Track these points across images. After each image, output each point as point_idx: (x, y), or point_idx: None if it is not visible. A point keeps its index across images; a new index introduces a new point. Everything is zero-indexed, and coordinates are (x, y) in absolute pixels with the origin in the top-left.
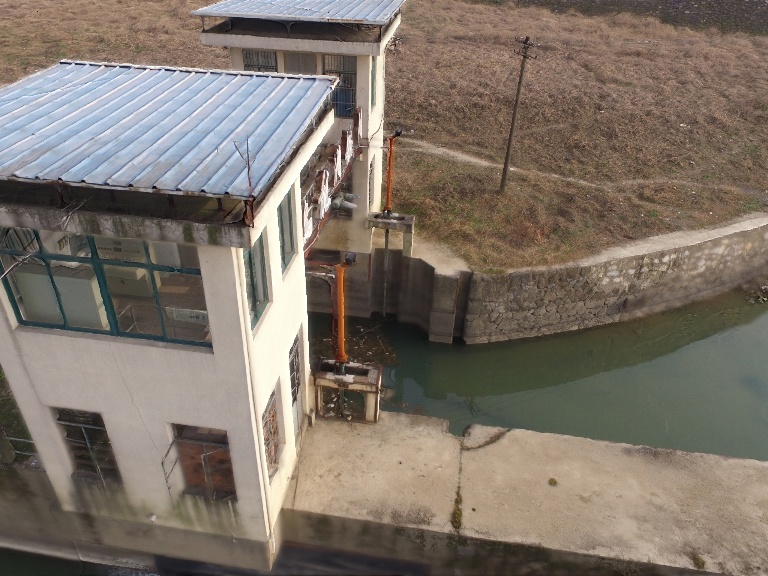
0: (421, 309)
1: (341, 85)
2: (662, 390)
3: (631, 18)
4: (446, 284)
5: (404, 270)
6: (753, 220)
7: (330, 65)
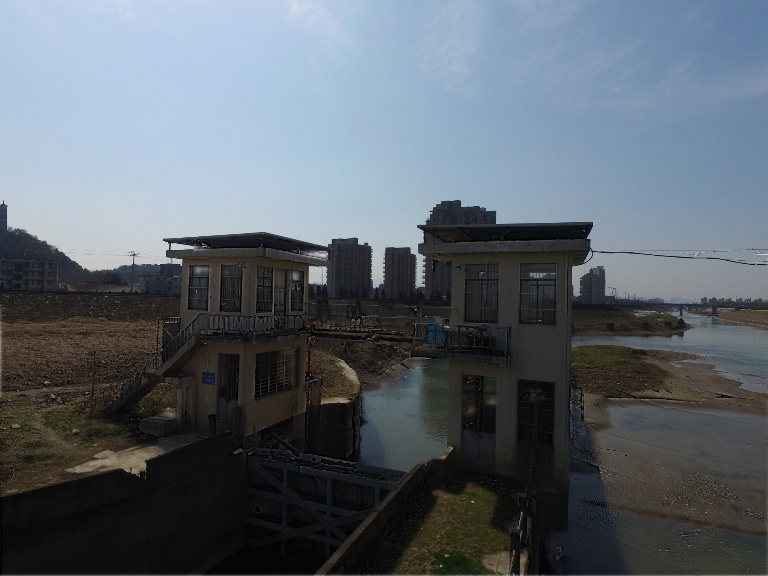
0: (328, 443)
1: (297, 289)
2: (408, 428)
3: (86, 319)
4: (350, 407)
5: (318, 417)
6: (341, 364)
7: (294, 277)
